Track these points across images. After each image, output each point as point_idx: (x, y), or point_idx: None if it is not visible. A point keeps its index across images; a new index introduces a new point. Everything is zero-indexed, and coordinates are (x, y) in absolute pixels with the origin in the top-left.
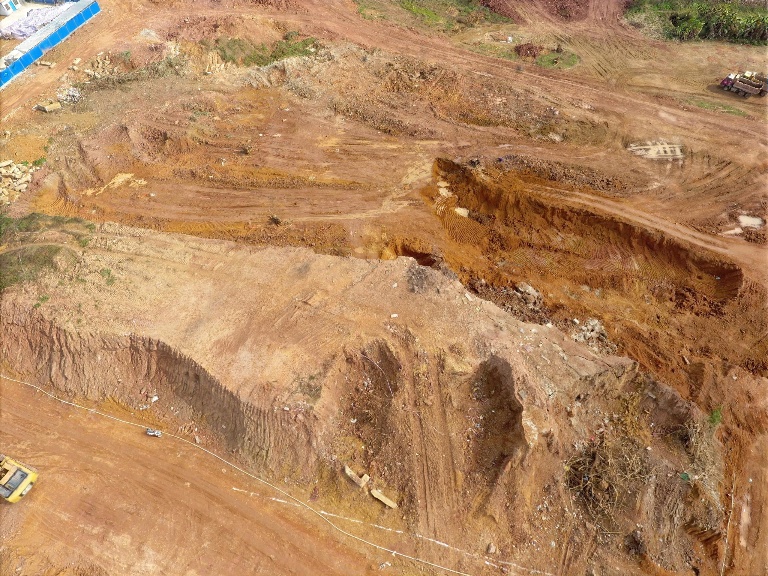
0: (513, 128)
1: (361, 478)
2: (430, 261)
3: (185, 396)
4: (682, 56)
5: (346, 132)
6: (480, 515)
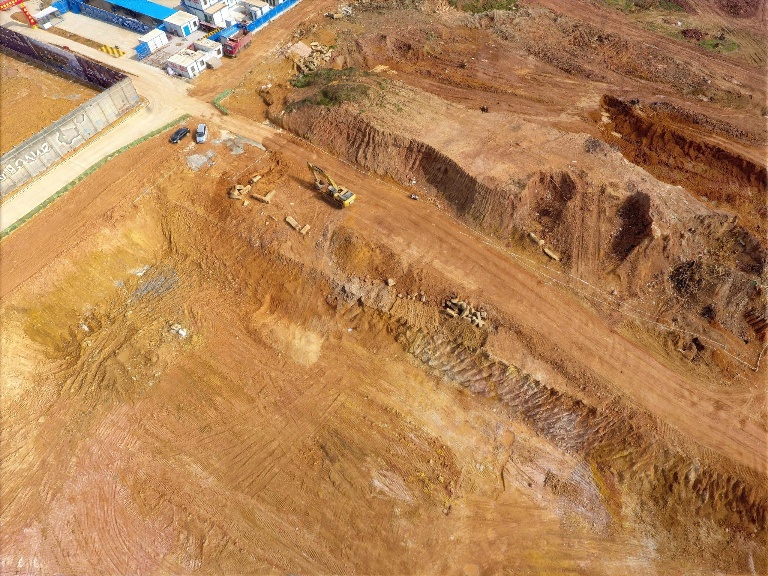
0: None
1: (540, 240)
2: None
3: (434, 183)
4: None
5: (536, 67)
6: (611, 273)
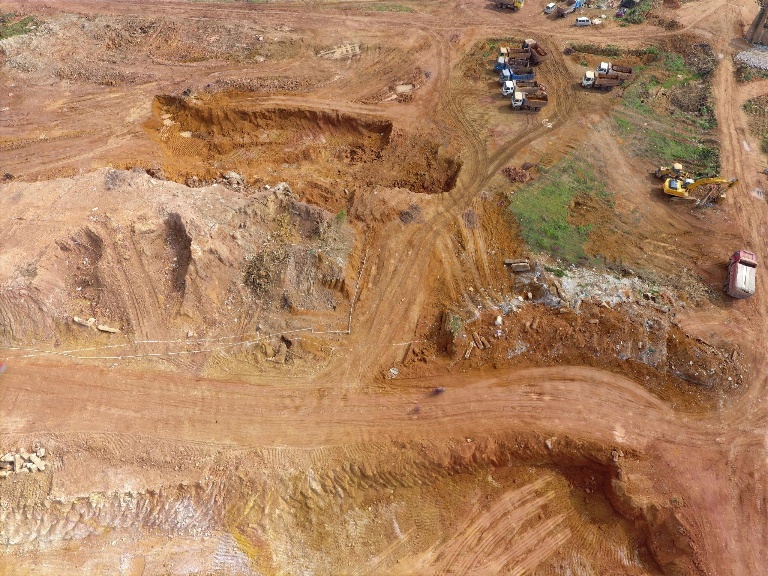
0: (225, 59)
1: (87, 321)
2: (151, 174)
3: None
4: None
5: (72, 93)
6: (177, 316)
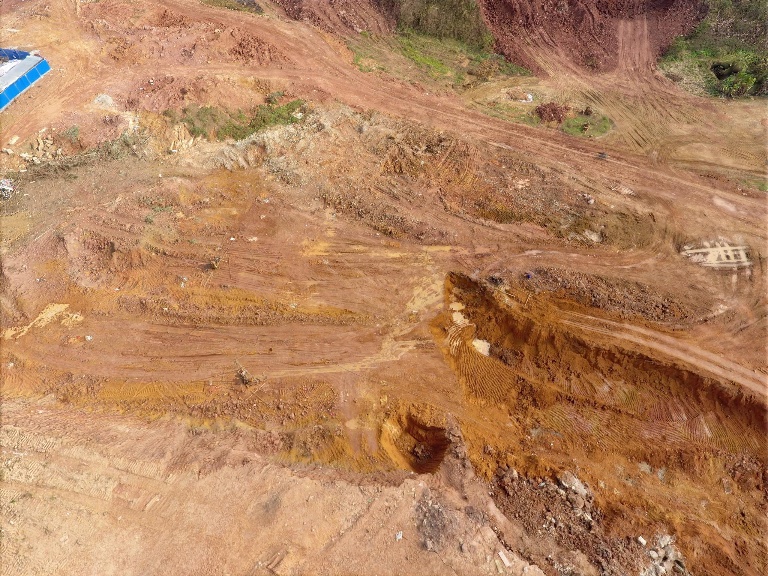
0: (540, 223)
1: None
2: (444, 439)
3: None
4: (731, 119)
5: (337, 233)
6: None
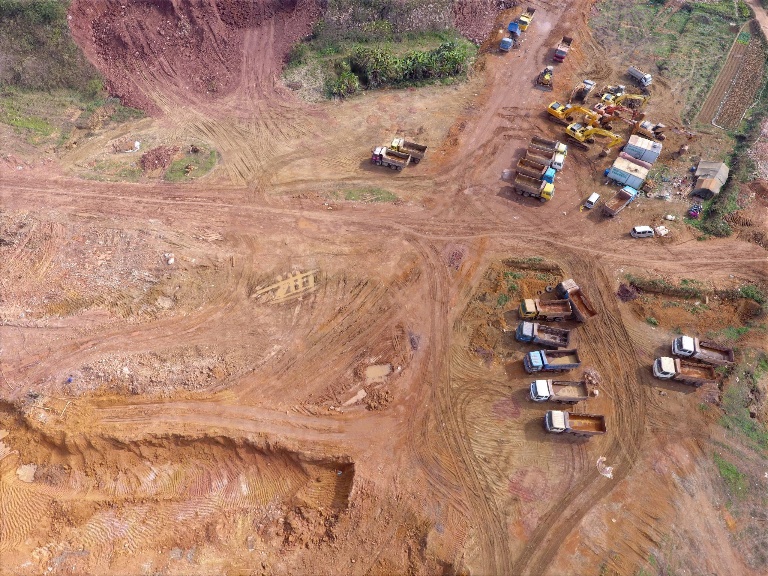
0: (112, 303)
1: None
2: None
3: None
4: (339, 122)
5: None
6: None
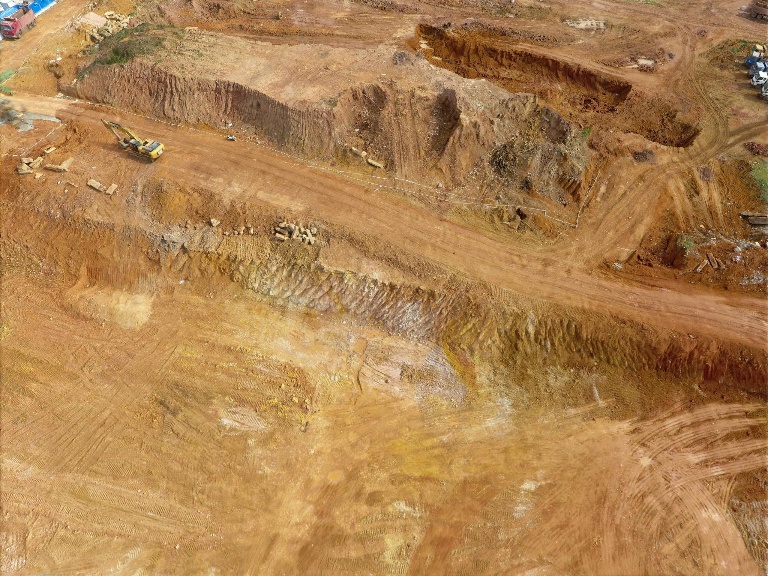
0: None
1: (362, 152)
2: None
3: (250, 121)
4: None
5: (352, 9)
6: (433, 168)
